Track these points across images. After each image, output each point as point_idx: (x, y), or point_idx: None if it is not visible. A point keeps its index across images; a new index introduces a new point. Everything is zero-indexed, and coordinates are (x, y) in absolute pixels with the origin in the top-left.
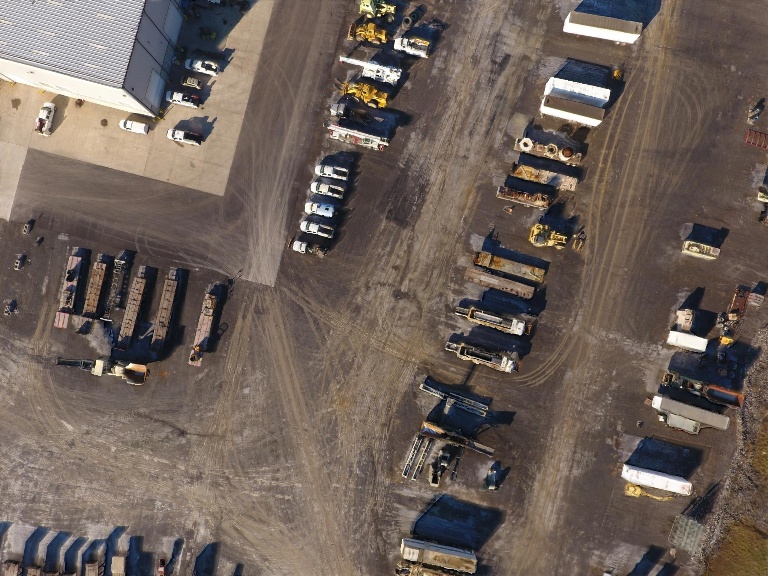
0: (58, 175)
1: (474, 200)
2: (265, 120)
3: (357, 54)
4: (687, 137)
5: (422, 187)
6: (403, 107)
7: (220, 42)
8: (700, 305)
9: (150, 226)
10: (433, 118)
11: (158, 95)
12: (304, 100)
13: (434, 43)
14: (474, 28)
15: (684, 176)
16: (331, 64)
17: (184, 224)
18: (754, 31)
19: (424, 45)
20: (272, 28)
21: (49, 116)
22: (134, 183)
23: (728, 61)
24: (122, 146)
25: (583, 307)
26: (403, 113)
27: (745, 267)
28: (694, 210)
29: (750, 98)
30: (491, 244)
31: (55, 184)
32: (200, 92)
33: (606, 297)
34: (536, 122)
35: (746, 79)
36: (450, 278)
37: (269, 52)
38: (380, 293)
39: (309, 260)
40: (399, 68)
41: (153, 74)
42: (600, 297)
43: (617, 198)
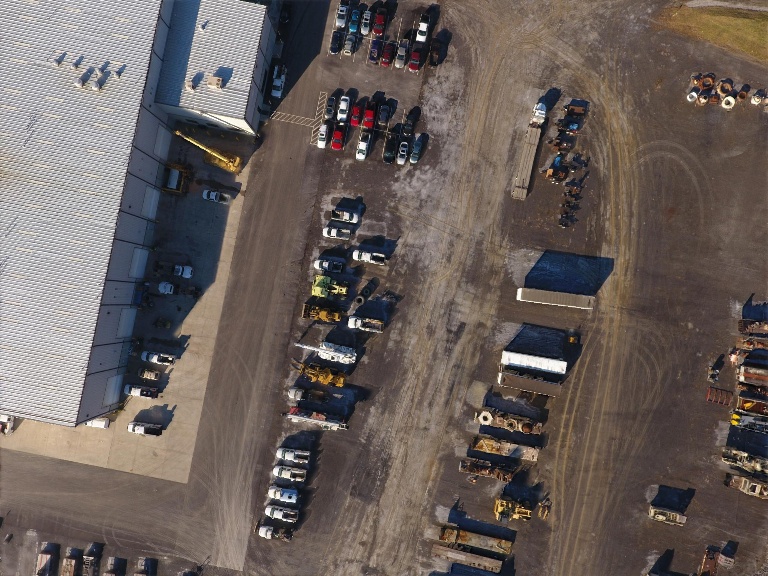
0: (23, 472)
1: (437, 471)
2: (224, 405)
3: (312, 332)
4: (648, 398)
5: (384, 461)
6: (361, 382)
7: (175, 329)
8: (670, 567)
9: (116, 517)
10: (392, 391)
11: (116, 390)
12: (262, 382)
13: (388, 316)
14: (428, 298)
15: (647, 437)
16: (287, 344)
17: (150, 514)
18: (709, 287)
19: (378, 323)
20: (226, 312)
21: (10, 417)
22: (98, 475)
23: (685, 318)
24: (84, 439)
25: (552, 575)
26: (361, 388)
27: (713, 527)
28: (659, 472)
29: (709, 355)
30: (457, 515)
31: (21, 481)
32: (158, 381)
33: (575, 564)
34: (495, 389)
35: (704, 336)
36: (418, 551)
37: (224, 336)
38: (349, 570)
39: (276, 542)
40: (355, 343)
41: (109, 381)
42: (569, 564)
43: (580, 463)
